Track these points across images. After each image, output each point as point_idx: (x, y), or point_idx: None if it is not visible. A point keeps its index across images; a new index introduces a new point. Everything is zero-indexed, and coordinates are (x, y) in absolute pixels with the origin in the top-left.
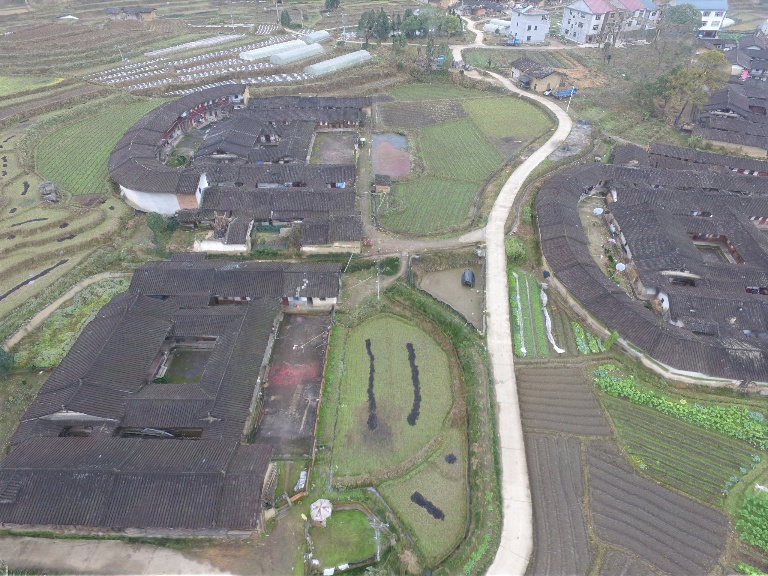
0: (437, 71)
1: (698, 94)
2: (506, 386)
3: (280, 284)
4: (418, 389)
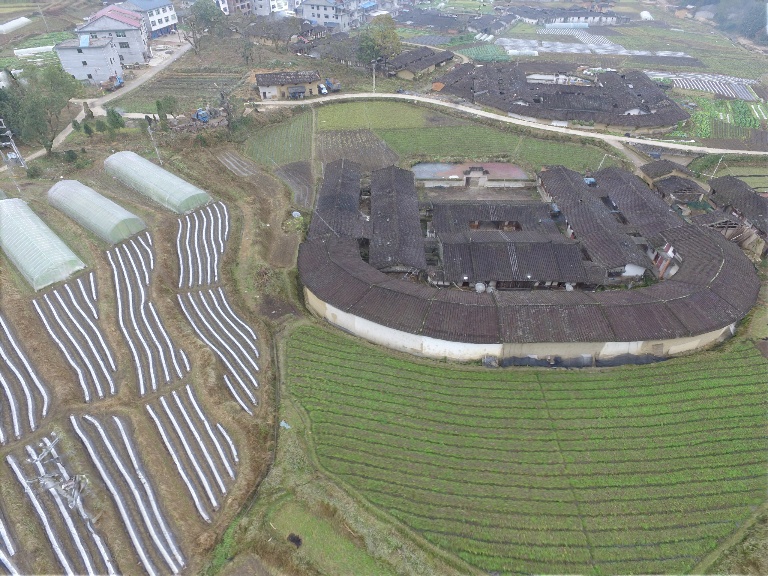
0: (236, 123)
1: (398, 46)
2: None
3: (765, 198)
4: (766, 175)
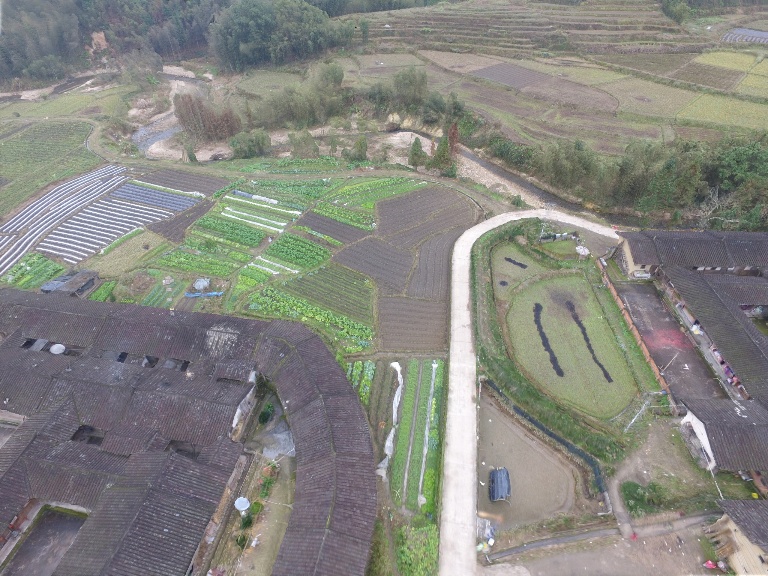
0: None
1: None
2: (460, 323)
3: None
4: (539, 329)
